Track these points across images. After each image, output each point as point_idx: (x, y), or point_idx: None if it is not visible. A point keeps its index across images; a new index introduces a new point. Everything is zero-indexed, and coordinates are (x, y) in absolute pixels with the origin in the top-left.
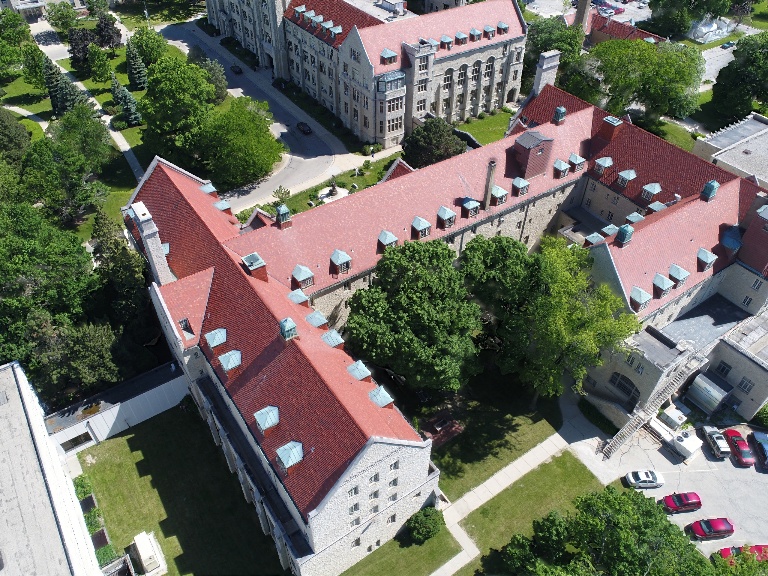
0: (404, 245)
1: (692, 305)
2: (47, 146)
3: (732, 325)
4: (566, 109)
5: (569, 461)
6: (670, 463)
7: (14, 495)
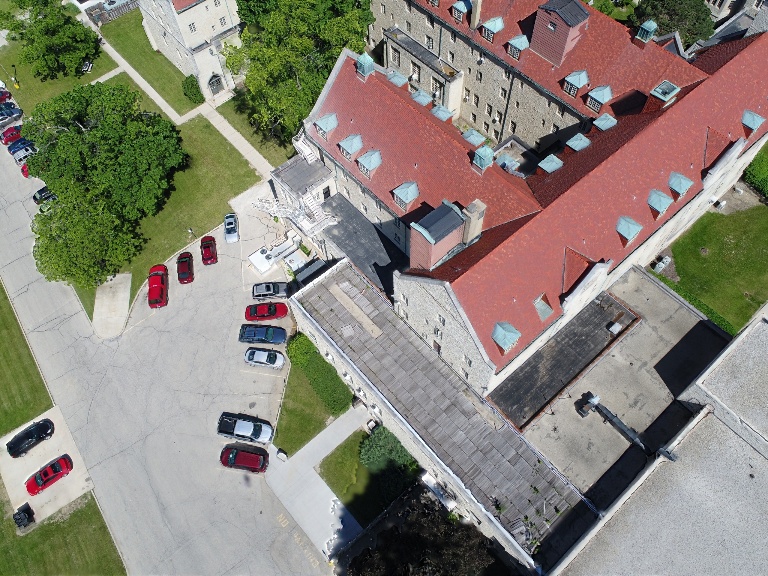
0: None
1: (396, 240)
2: None
3: (376, 282)
4: (711, 64)
5: (251, 179)
6: (250, 253)
7: None
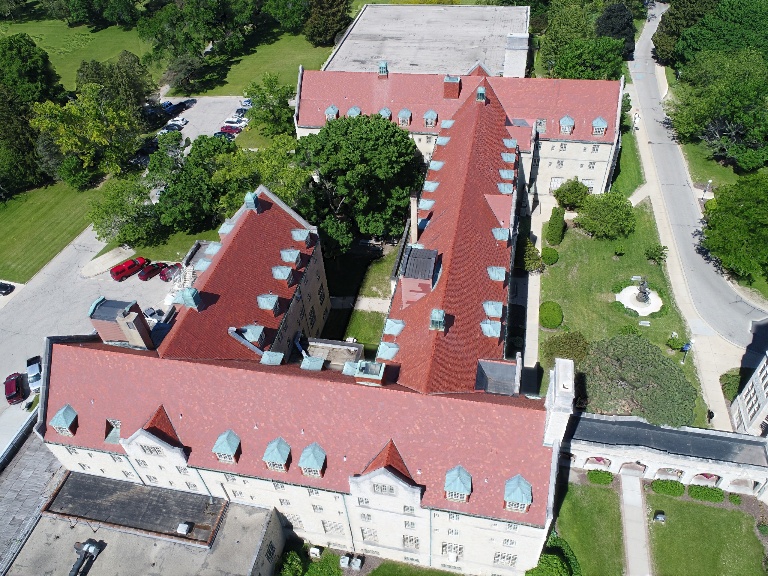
0: (398, 134)
1: None
2: (753, 85)
3: None
4: None
5: None
6: None
7: (440, 70)
